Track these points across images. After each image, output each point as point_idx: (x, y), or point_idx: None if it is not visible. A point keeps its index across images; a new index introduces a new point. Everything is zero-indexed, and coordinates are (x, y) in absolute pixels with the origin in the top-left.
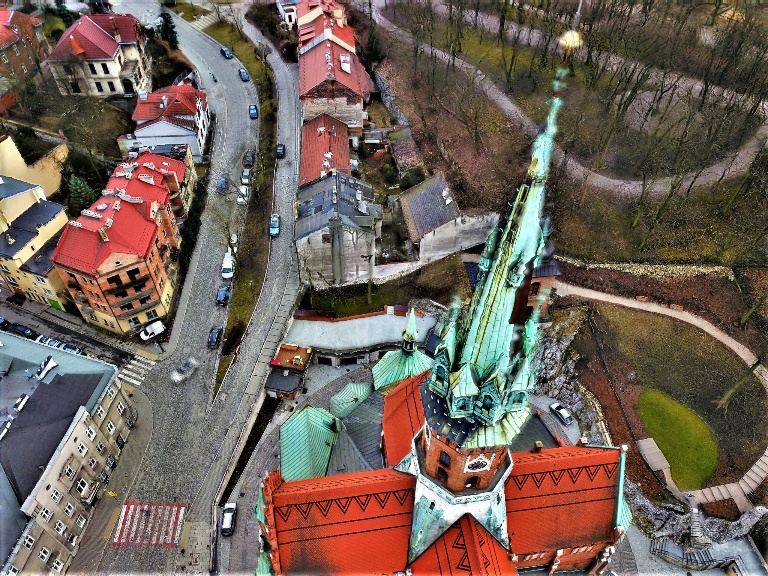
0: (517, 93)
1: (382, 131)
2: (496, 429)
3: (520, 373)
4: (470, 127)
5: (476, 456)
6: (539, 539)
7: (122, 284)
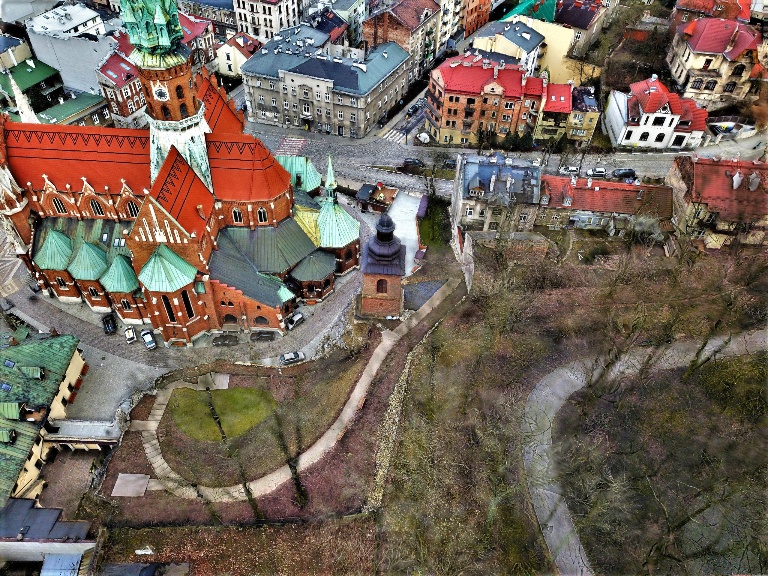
0: None
1: (676, 250)
2: None
3: None
4: (623, 260)
5: None
6: None
7: (435, 94)
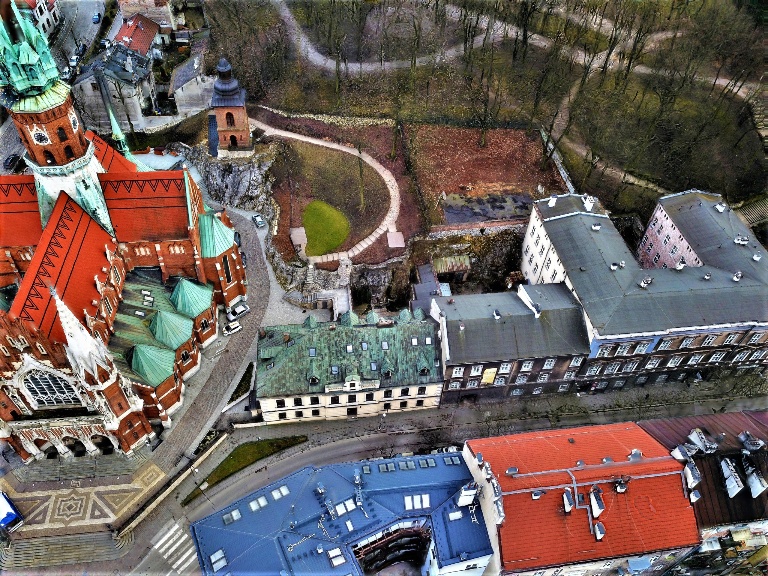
0: (299, 6)
1: (189, 32)
2: (32, 101)
3: (21, 51)
4: (233, 19)
5: (33, 126)
6: (136, 232)
7: None
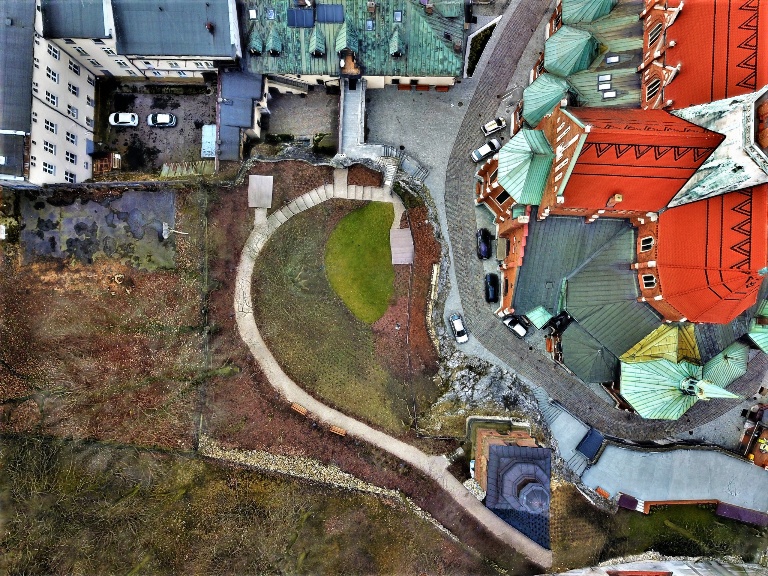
0: None
1: None
2: None
3: None
4: None
5: None
6: None
7: None
